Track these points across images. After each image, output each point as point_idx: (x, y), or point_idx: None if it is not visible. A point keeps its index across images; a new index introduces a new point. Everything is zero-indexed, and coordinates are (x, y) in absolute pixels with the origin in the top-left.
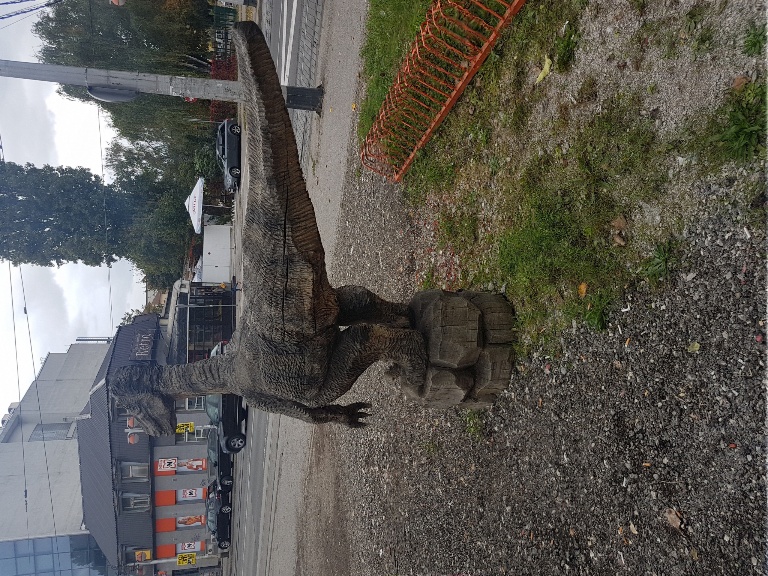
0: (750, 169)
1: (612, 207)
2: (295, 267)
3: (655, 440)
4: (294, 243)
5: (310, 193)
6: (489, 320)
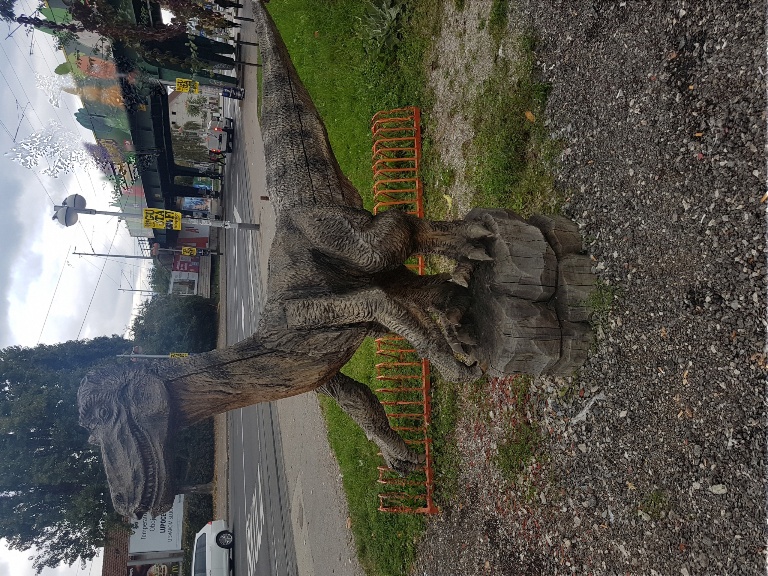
0: (510, 1)
1: None
2: (305, 117)
3: None
4: None
5: None
6: None
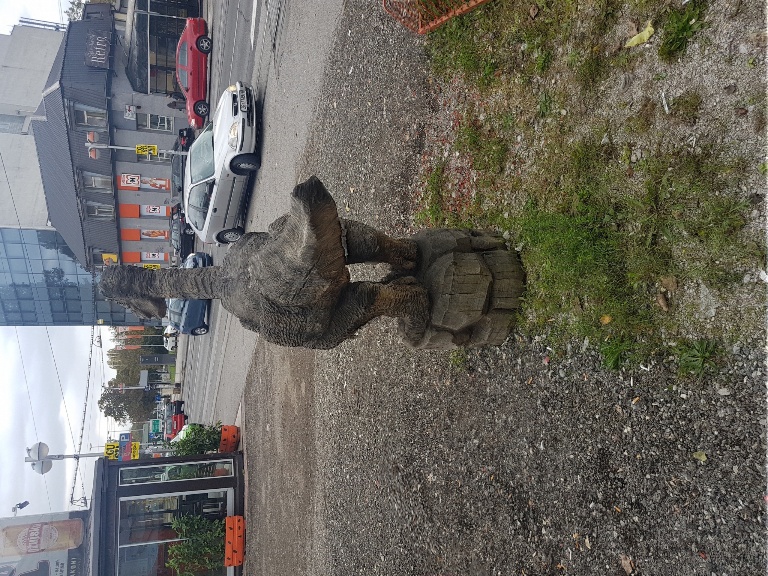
0: None
1: (667, 262)
2: (314, 281)
3: (632, 497)
4: (318, 272)
5: None
6: (499, 287)
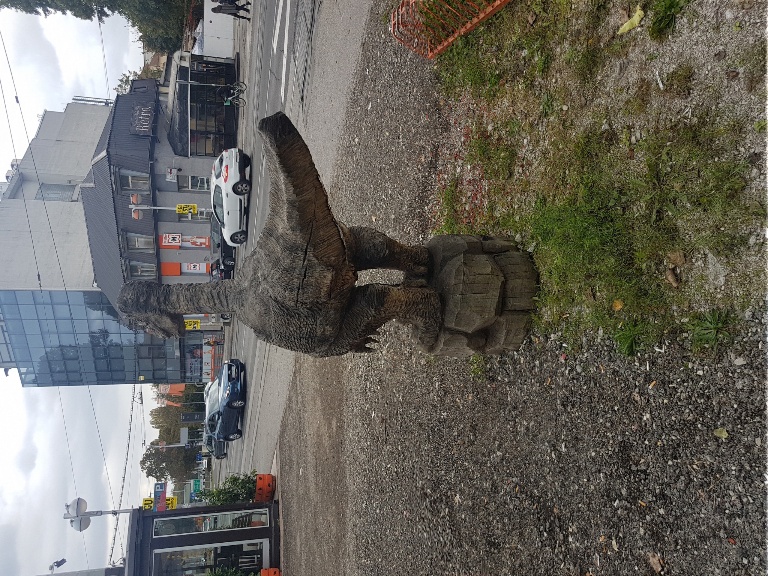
0: None
1: (673, 237)
2: (314, 269)
3: (656, 488)
4: (315, 256)
5: (337, 223)
6: (511, 287)
